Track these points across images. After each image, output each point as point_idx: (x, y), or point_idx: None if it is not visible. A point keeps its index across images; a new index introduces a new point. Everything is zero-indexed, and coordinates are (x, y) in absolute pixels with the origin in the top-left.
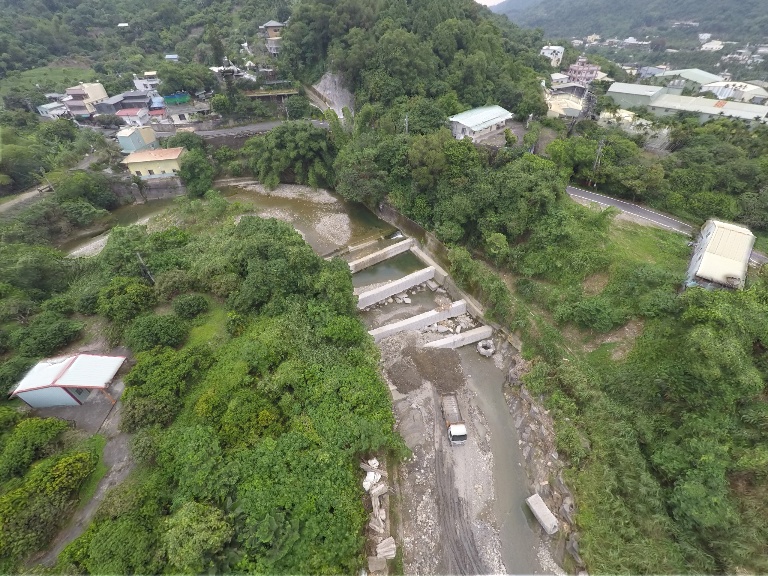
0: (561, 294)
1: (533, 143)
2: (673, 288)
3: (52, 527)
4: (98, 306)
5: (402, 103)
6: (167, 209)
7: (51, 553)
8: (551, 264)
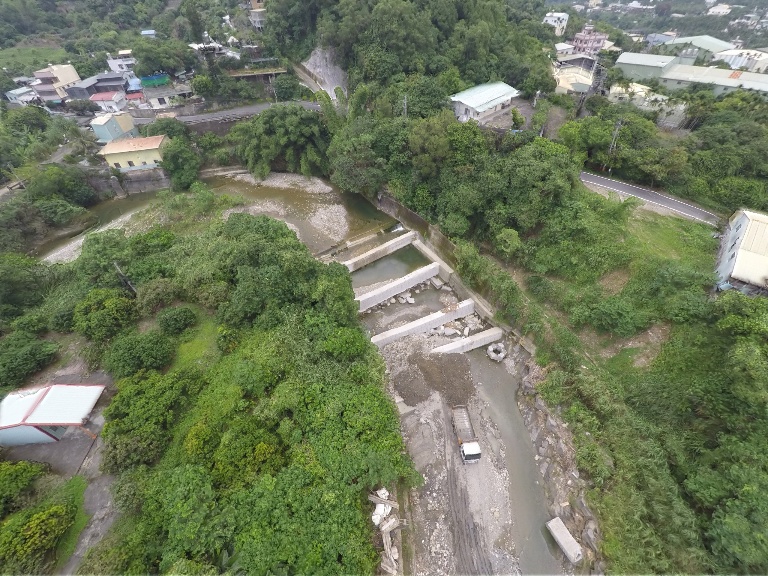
0: None
1: (543, 124)
2: (703, 289)
3: None
4: (74, 324)
5: (399, 82)
6: (150, 204)
7: None
8: (565, 260)
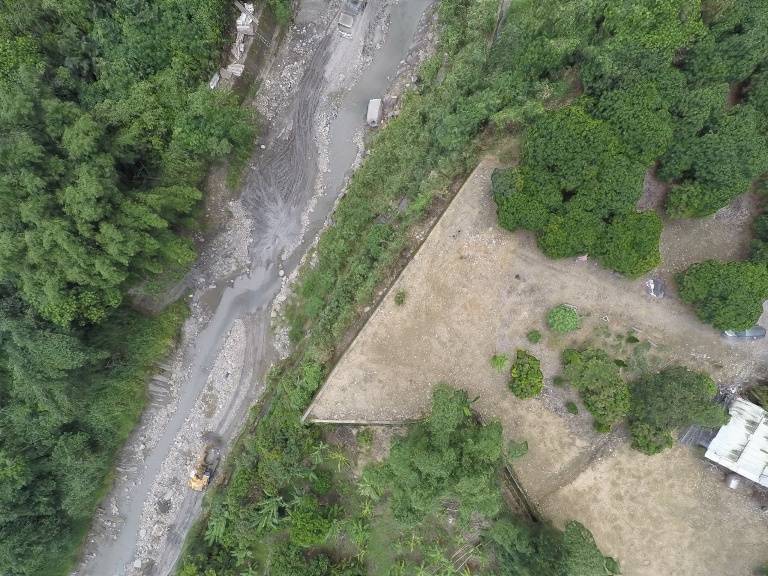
0: None
1: None
2: None
3: None
4: None
5: None
6: None
7: None
8: None
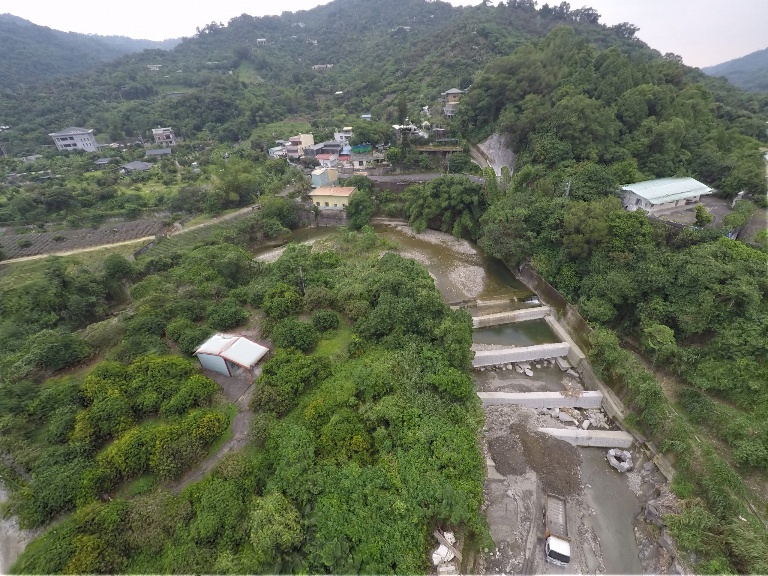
0: (751, 426)
1: (737, 227)
2: None
3: (187, 466)
4: (263, 302)
5: (568, 167)
6: (330, 235)
7: (180, 486)
8: (740, 382)
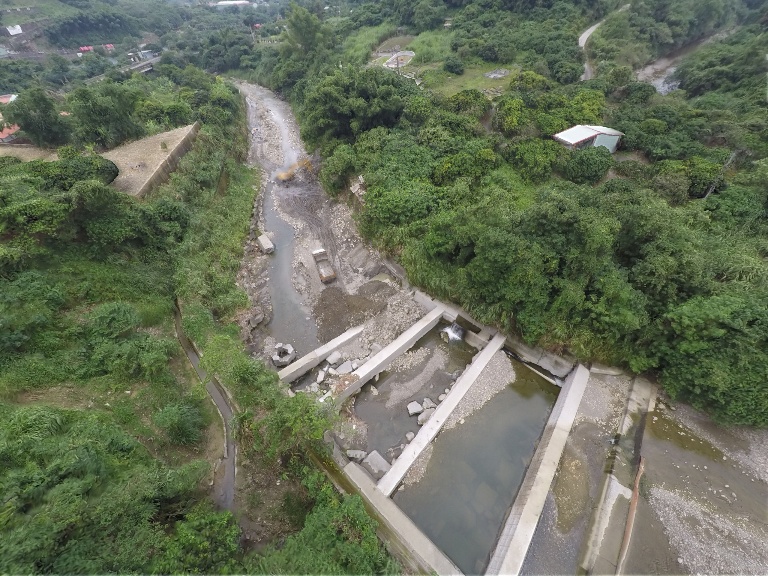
0: None
1: None
2: None
3: None
4: None
5: None
6: None
7: None
8: None
